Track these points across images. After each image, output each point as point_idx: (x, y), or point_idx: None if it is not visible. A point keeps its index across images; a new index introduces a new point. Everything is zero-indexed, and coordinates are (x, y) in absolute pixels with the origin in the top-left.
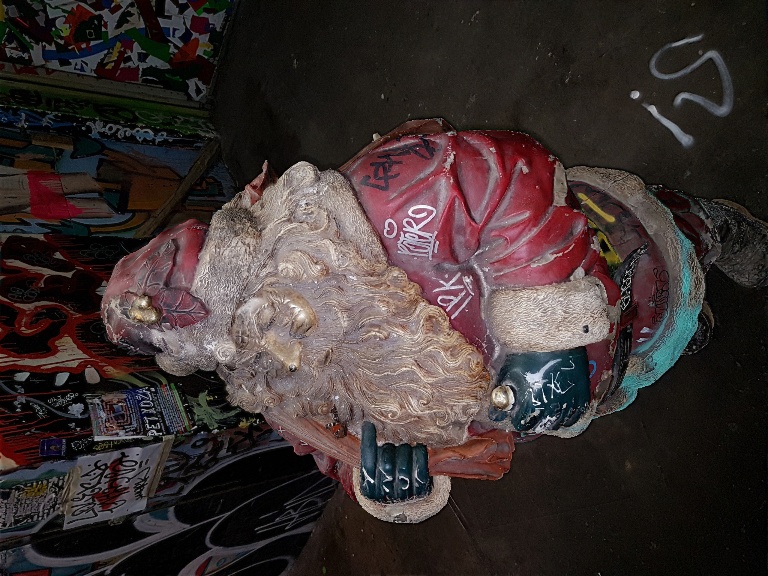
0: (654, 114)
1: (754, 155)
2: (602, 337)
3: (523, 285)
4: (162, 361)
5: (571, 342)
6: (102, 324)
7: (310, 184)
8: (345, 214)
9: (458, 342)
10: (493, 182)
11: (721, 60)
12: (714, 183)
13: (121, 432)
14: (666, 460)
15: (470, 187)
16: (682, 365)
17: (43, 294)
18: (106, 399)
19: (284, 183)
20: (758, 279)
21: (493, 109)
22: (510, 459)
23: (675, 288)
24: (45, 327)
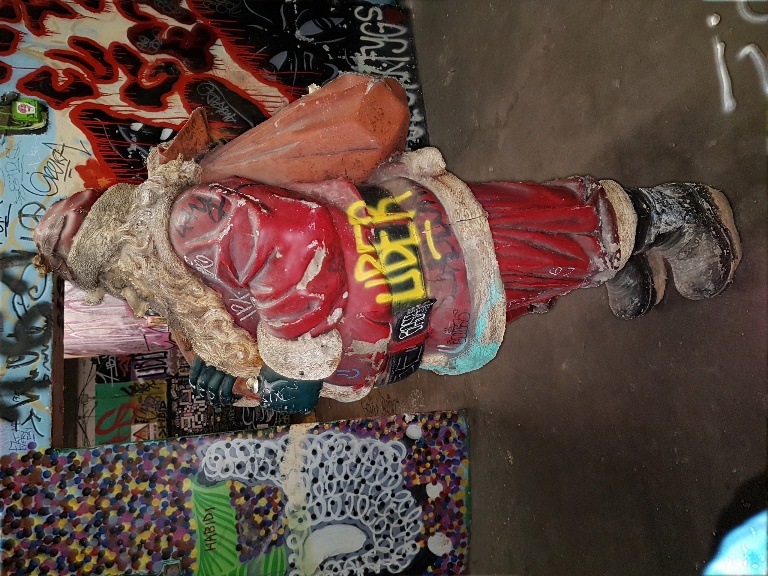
0: (719, 55)
1: None
2: (320, 378)
3: (266, 330)
4: None
5: (291, 376)
6: (208, 85)
7: (147, 206)
8: (158, 242)
9: (234, 341)
10: (253, 257)
11: None
12: (728, 168)
13: None
14: (585, 380)
15: (237, 255)
16: None
17: (164, 46)
18: None
19: (135, 195)
20: (686, 293)
21: None
22: None
23: (472, 328)
24: (161, 82)
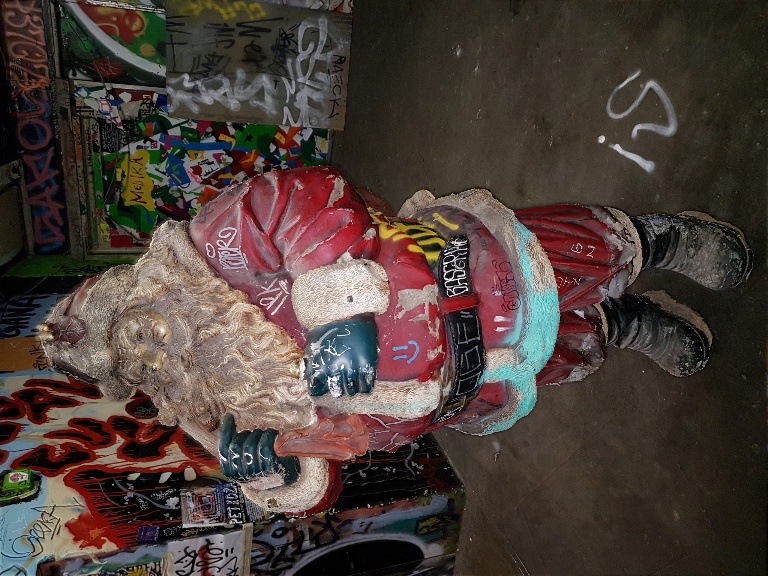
0: (619, 151)
1: (706, 162)
2: (372, 306)
3: (301, 273)
4: (101, 388)
5: (339, 311)
6: None
7: (166, 232)
8: (179, 246)
9: (268, 330)
10: (275, 201)
11: (658, 87)
12: (680, 199)
13: (206, 520)
14: (708, 502)
15: (259, 208)
16: (698, 391)
17: None
18: (197, 492)
19: (154, 236)
20: (719, 278)
21: (503, 187)
22: (366, 444)
23: (519, 276)
24: (158, 436)
